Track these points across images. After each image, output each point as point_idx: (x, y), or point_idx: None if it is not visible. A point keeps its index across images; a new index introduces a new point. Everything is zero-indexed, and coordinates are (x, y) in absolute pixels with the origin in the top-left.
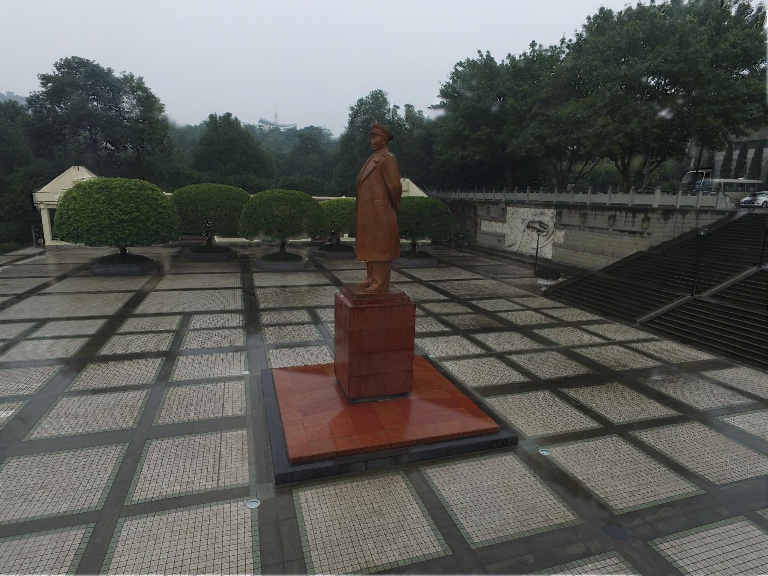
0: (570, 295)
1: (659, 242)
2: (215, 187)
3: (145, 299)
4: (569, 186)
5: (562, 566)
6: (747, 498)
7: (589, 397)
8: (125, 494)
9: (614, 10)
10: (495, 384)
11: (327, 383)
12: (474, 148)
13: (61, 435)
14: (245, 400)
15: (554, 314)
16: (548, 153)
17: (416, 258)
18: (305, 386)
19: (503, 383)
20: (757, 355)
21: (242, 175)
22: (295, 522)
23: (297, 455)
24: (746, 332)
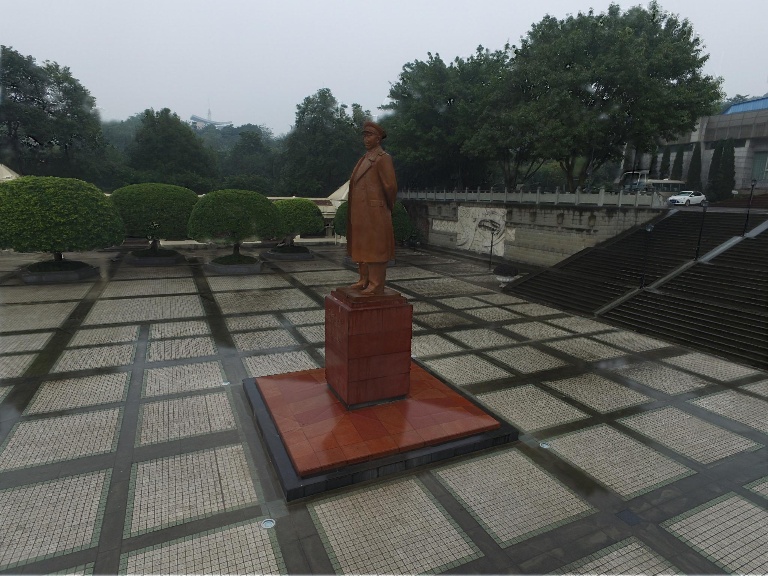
0: (529, 291)
1: (604, 239)
2: (160, 187)
3: (92, 309)
4: (518, 186)
5: (590, 556)
6: (732, 475)
7: (571, 389)
8: (121, 526)
9: (556, 19)
10: (481, 381)
11: (319, 390)
12: (426, 148)
13: (29, 466)
14: (232, 413)
15: (518, 310)
16: (499, 154)
17: None
18: (296, 394)
19: (489, 380)
20: (706, 341)
21: (185, 174)
22: (318, 539)
23: (306, 468)
24: (693, 320)
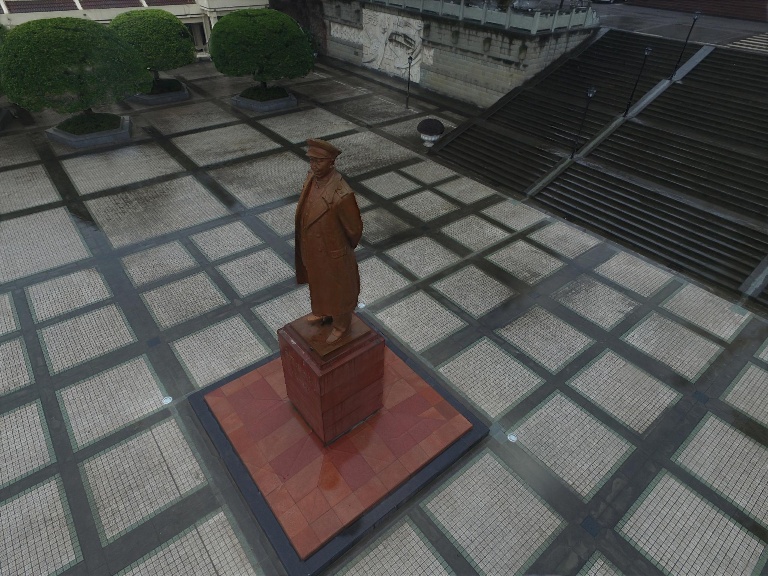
0: (457, 156)
1: (533, 74)
2: None
3: None
4: None
5: None
6: (662, 444)
7: (522, 338)
8: None
9: None
10: (438, 341)
11: (284, 412)
12: None
13: None
14: (193, 456)
15: (451, 193)
16: None
17: (271, 100)
18: (261, 424)
19: (445, 337)
20: (630, 235)
21: None
22: None
23: (307, 551)
24: (620, 206)
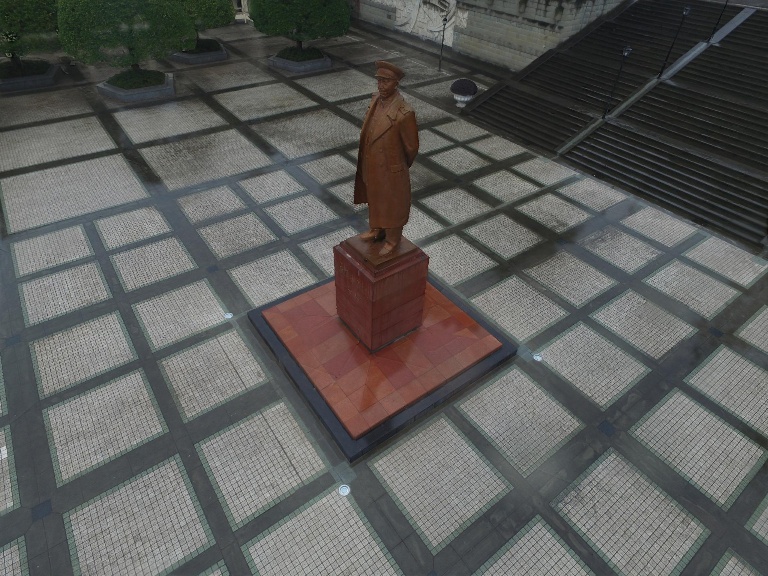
0: (490, 116)
1: (568, 36)
2: None
3: (2, 198)
4: None
5: (585, 473)
6: (676, 368)
7: (549, 277)
8: (225, 519)
9: None
10: (471, 277)
11: (334, 326)
12: None
13: (96, 466)
14: (255, 359)
15: (483, 150)
16: None
17: (306, 60)
18: (313, 335)
19: (477, 274)
20: (657, 191)
21: None
22: (389, 498)
23: (359, 432)
24: (648, 164)
